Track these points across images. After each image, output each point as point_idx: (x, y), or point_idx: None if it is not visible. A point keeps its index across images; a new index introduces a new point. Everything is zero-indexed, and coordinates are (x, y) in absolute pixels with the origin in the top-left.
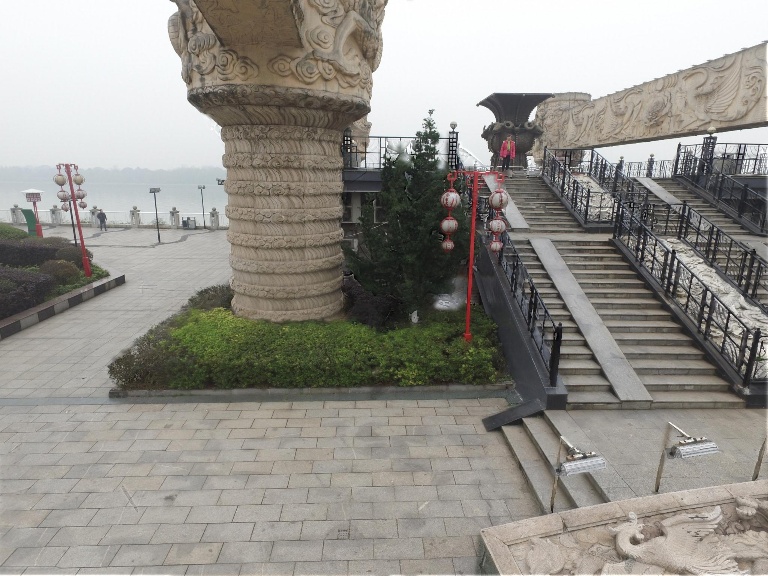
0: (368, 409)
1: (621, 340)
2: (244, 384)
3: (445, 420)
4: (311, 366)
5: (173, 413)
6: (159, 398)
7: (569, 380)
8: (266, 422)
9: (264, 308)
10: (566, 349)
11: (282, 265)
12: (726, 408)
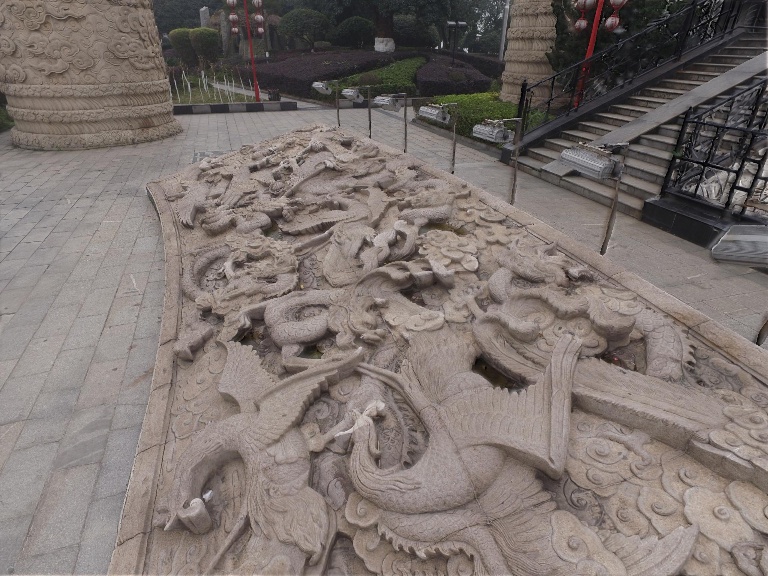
0: (462, 149)
1: (650, 140)
2: (444, 125)
3: (473, 162)
4: (464, 118)
5: (410, 128)
6: (421, 125)
7: (542, 150)
8: (421, 138)
9: (504, 91)
10: (588, 135)
11: (515, 53)
12: (620, 211)
